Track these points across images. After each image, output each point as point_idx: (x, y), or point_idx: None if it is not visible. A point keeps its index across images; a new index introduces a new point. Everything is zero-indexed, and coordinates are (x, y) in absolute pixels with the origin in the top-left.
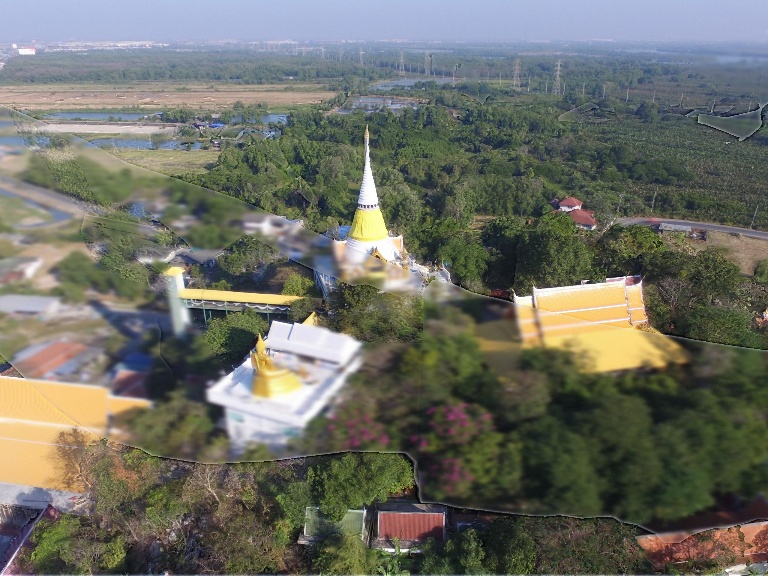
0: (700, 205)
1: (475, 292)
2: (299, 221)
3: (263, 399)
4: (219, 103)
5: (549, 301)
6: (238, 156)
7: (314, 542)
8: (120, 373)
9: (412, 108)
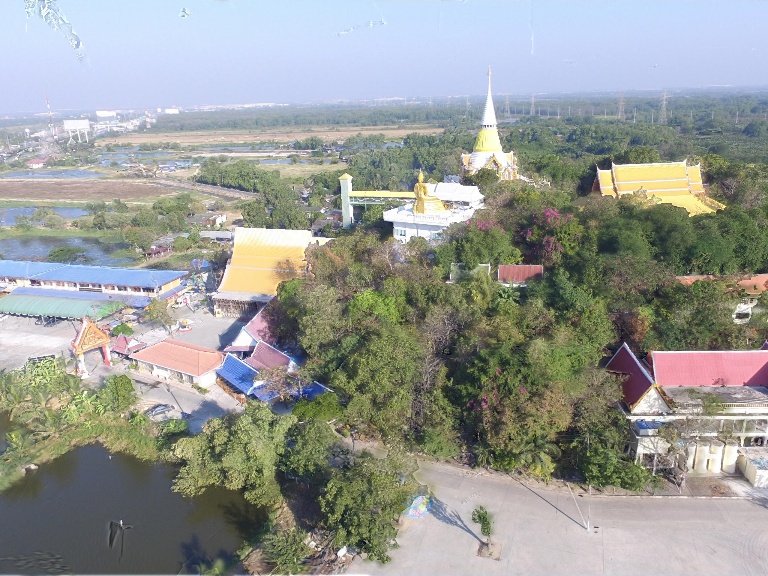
0: None
1: (569, 190)
2: None
3: (474, 6)
4: (342, 136)
5: (624, 174)
6: (366, 161)
7: None
8: (422, 3)
9: (518, 130)
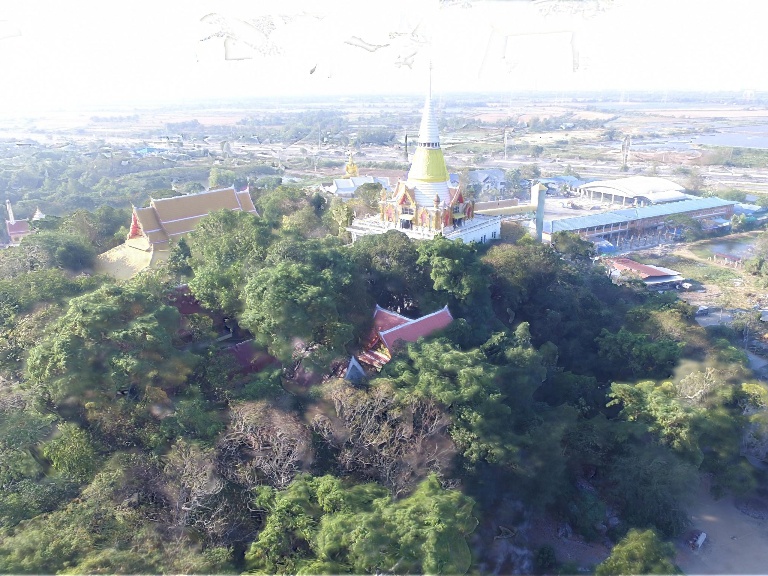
0: None
1: None
2: None
3: None
4: None
5: None
6: None
7: None
8: None
9: None
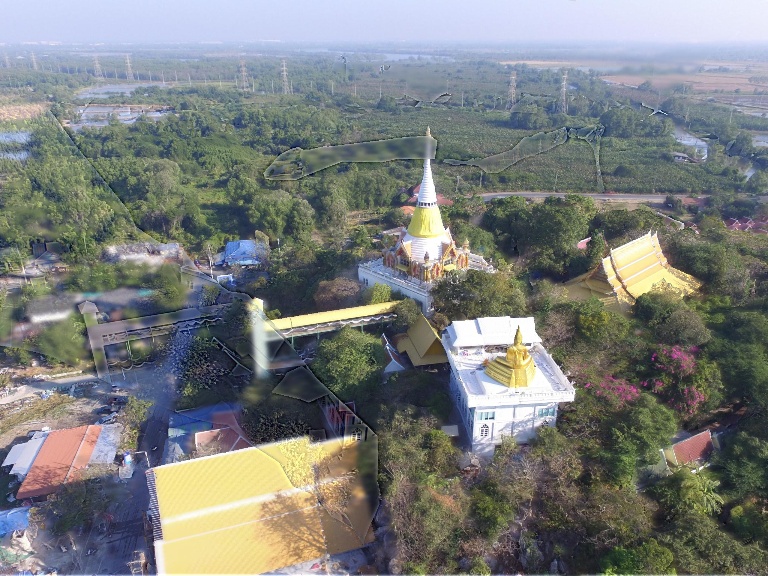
0: (510, 178)
1: (520, 267)
2: (176, 244)
3: None
4: None
5: (620, 258)
6: None
7: (645, 488)
8: None
9: (174, 115)
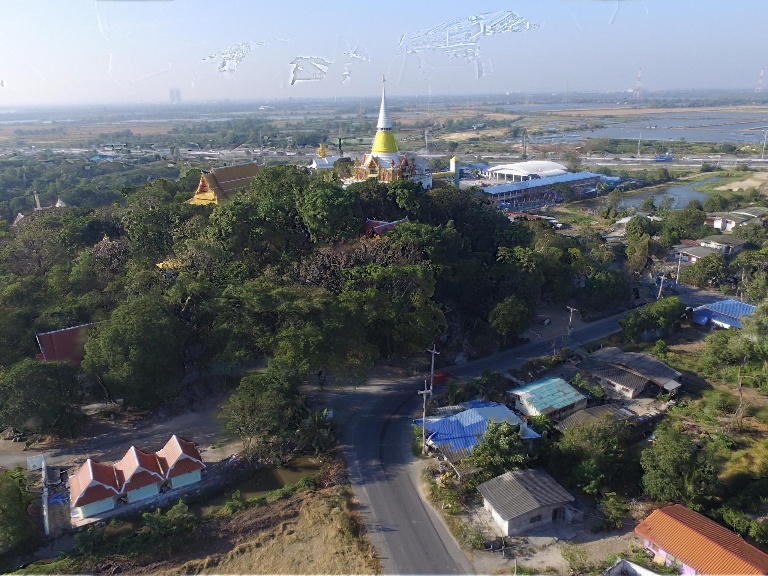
0: None
1: None
2: None
3: None
4: None
5: None
6: None
7: None
8: None
9: None
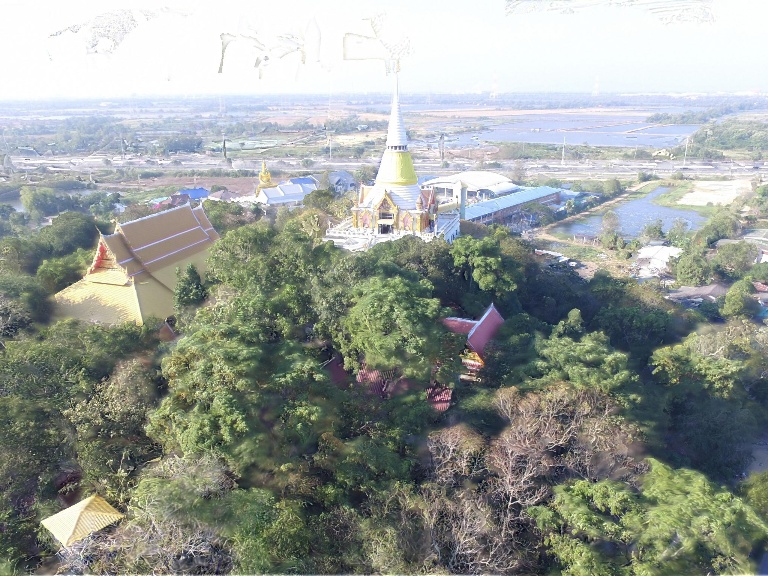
0: None
1: None
2: None
3: None
4: None
5: None
6: None
7: None
8: None
9: None
